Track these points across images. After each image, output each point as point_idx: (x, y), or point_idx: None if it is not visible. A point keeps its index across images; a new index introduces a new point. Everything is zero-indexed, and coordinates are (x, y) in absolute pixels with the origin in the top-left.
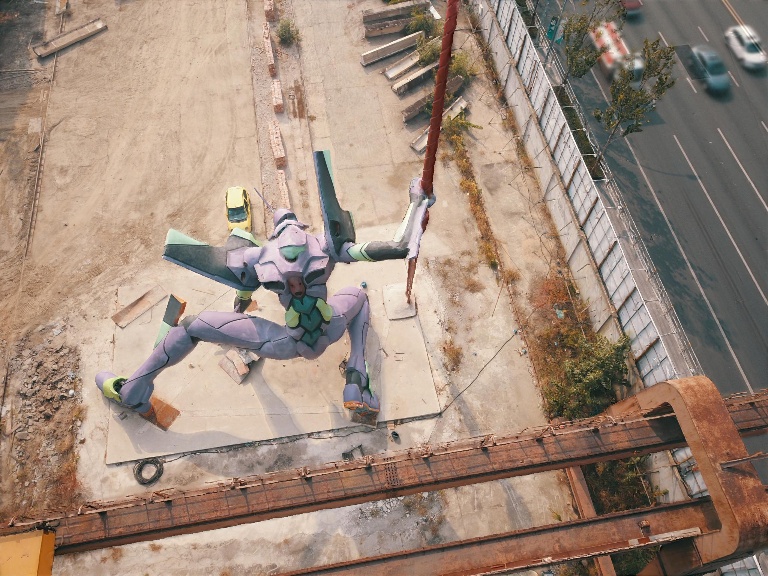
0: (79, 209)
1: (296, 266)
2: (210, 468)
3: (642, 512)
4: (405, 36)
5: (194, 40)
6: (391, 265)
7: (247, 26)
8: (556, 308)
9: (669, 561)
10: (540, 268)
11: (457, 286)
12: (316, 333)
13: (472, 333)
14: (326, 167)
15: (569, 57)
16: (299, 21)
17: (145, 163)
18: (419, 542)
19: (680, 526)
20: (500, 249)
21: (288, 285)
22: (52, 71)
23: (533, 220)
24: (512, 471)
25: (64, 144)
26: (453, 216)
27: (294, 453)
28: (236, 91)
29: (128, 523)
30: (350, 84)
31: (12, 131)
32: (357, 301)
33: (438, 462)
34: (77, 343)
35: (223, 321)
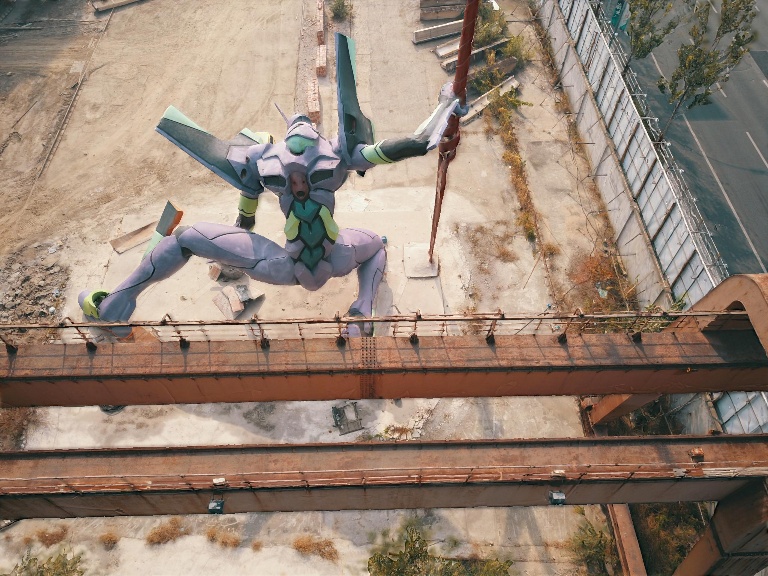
0: (102, 142)
1: (301, 158)
2: (182, 404)
3: (694, 438)
4: (461, 19)
5: (248, 9)
6: (417, 225)
7: (303, 1)
8: (599, 287)
9: (727, 522)
10: (584, 245)
11: (487, 254)
12: (317, 250)
13: (499, 302)
14: (348, 56)
15: (634, 38)
16: (355, 1)
17: (177, 108)
18: (408, 518)
19: (746, 463)
20: (540, 223)
21: (290, 182)
22: (106, 23)
23: (580, 198)
24: (523, 371)
25: (102, 85)
26: (491, 186)
27: (278, 401)
28: (281, 54)
29: (38, 366)
30: (398, 58)
31: (55, 69)
32: (372, 242)
33: (430, 349)
34: (70, 263)
35: (218, 232)
